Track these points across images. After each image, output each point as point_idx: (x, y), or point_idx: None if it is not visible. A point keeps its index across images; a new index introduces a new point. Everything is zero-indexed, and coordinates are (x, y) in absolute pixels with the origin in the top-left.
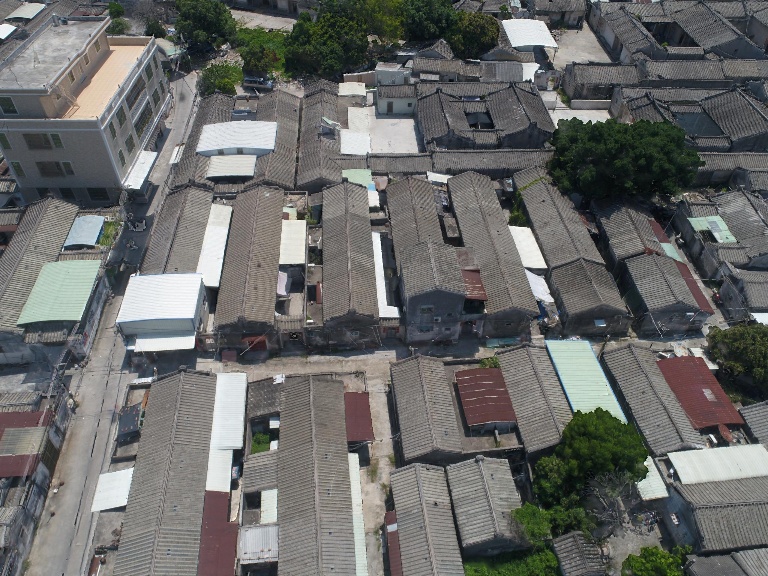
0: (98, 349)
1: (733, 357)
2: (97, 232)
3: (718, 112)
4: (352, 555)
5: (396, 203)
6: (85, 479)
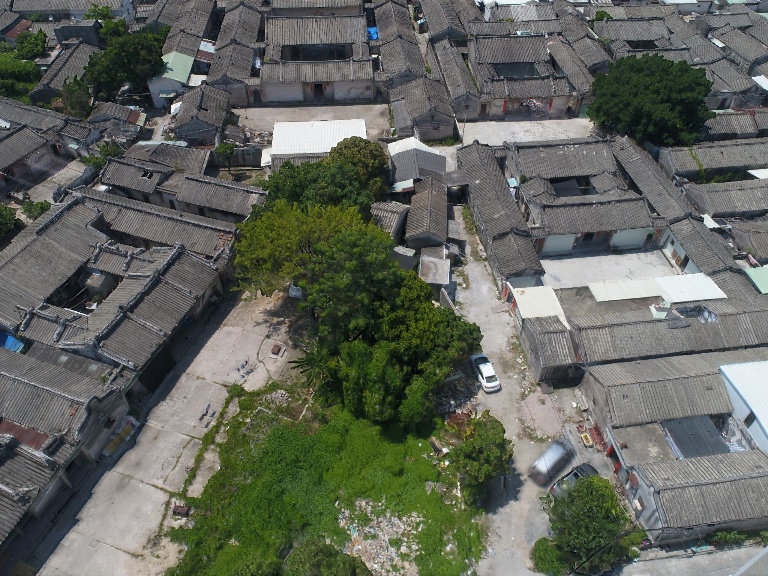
0: None
1: None
2: None
3: (503, 57)
4: None
5: None
6: None
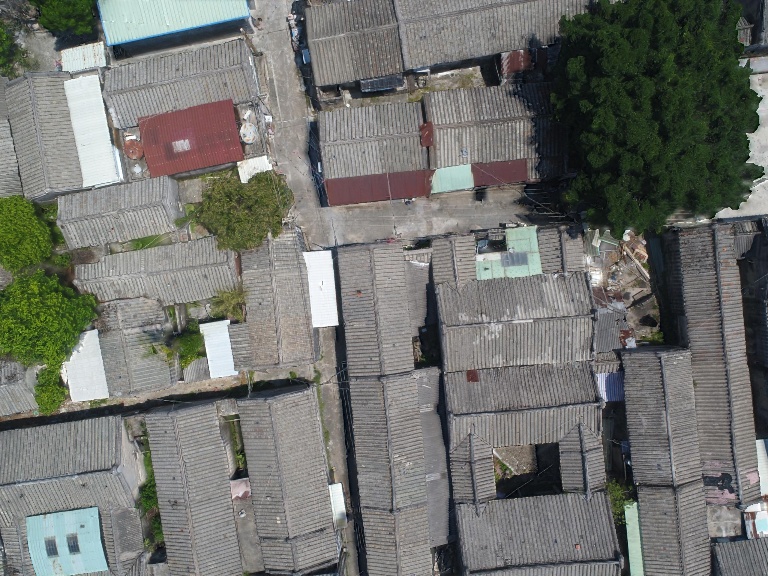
0: None
1: None
2: None
3: None
4: None
5: None
6: None
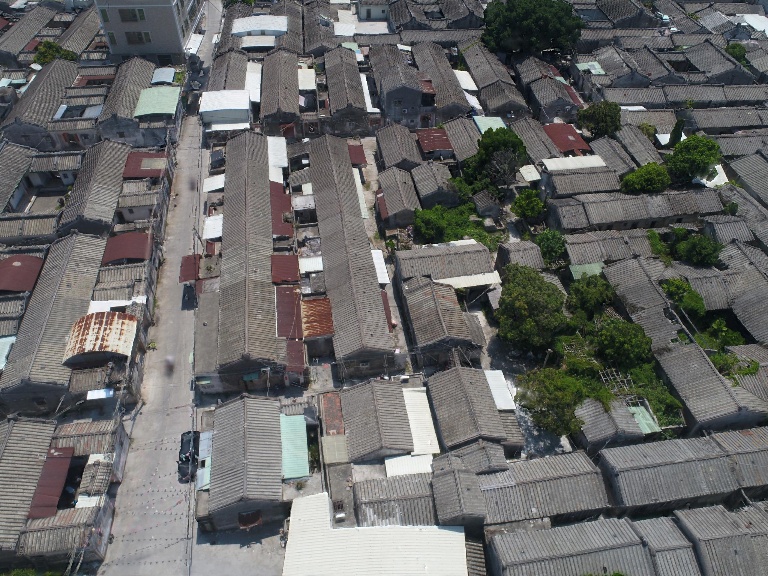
0: (183, 140)
1: (589, 121)
2: (172, 76)
3: (607, 7)
4: (358, 202)
5: (376, 59)
6: (198, 176)
